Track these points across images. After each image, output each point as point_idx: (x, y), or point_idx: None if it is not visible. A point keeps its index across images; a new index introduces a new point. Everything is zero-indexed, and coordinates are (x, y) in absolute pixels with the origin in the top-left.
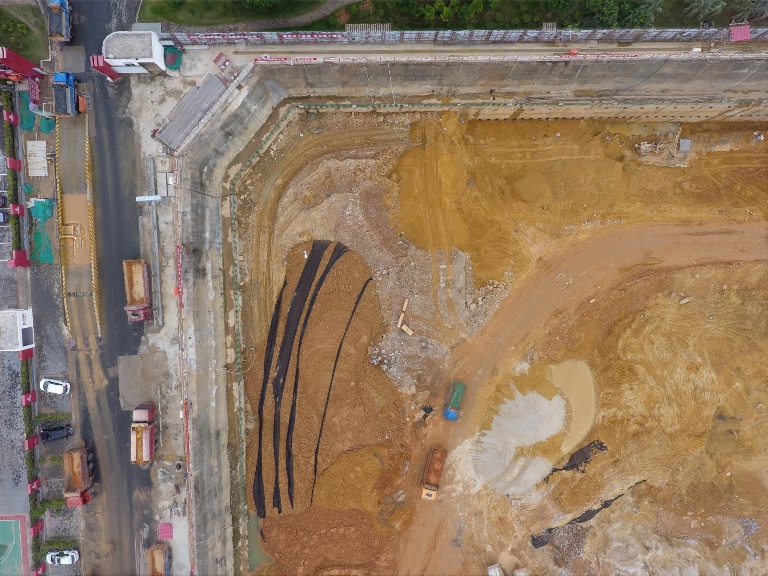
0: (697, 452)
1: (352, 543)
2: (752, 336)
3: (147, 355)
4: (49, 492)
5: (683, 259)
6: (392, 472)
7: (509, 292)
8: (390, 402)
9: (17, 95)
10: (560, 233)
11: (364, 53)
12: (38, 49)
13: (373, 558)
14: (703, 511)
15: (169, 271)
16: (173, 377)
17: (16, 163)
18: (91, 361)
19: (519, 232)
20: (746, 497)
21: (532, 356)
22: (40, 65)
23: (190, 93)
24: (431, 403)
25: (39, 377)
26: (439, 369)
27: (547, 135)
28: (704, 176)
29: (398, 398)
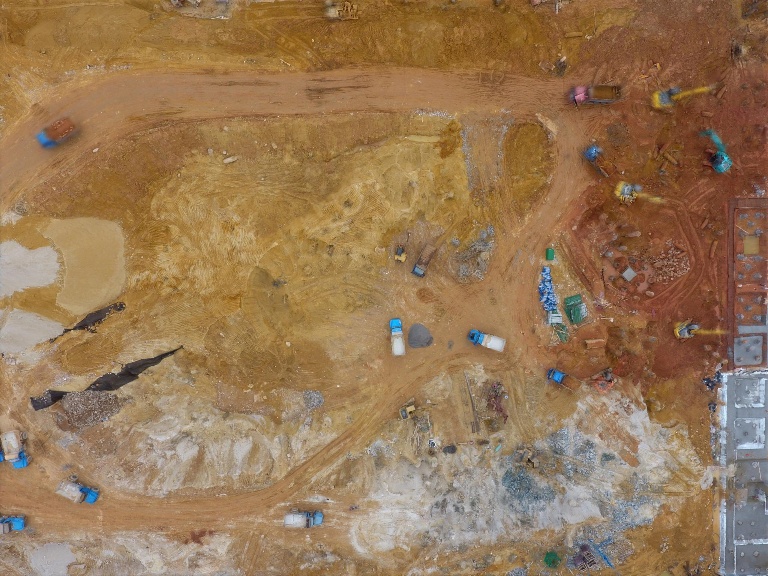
0: (234, 315)
1: None
2: (309, 199)
3: None
4: None
5: (208, 110)
6: None
7: None
8: None
9: None
10: (58, 78)
11: None
12: None
13: None
14: (265, 384)
15: None
16: None
17: None
18: None
19: (12, 76)
20: (308, 368)
21: (21, 206)
22: None
23: None
24: None
25: None
26: None
27: None
28: (248, 28)
29: None
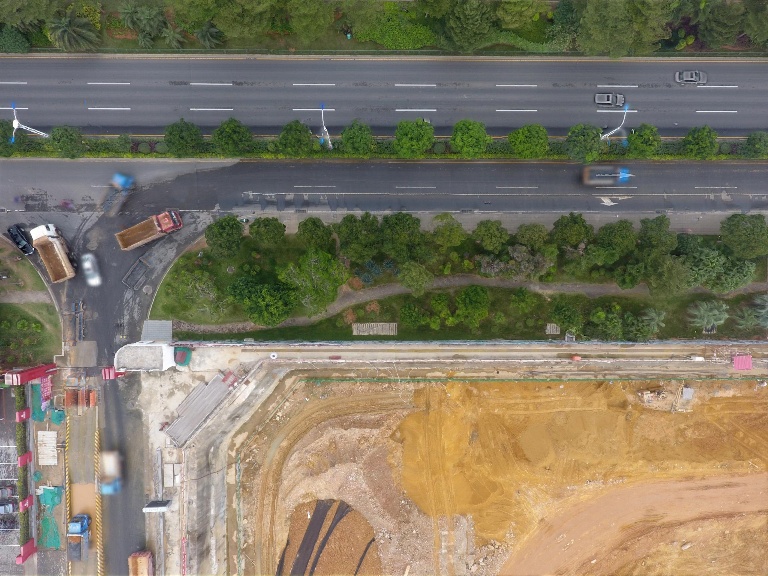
0: None
1: None
2: None
3: None
4: None
5: (685, 513)
6: None
7: (510, 555)
8: None
9: (30, 388)
10: (562, 493)
11: (370, 352)
12: (52, 345)
13: None
14: None
15: (173, 558)
16: None
17: (27, 456)
18: None
19: (521, 493)
20: None
21: None
22: (53, 360)
23: (199, 389)
24: None
25: None
26: None
27: (550, 387)
28: (707, 421)
29: None
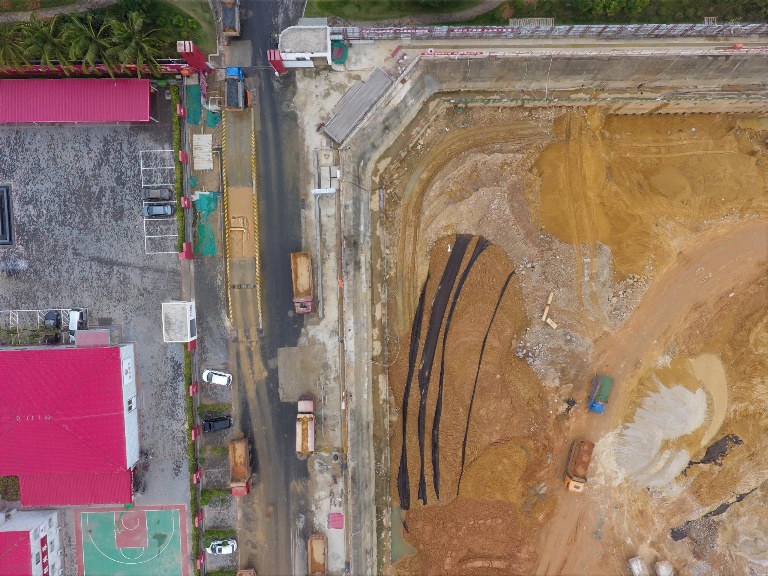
0: None
1: (497, 535)
2: None
3: (306, 347)
4: (208, 482)
5: None
6: (536, 464)
7: (650, 286)
8: (535, 395)
9: (185, 89)
10: (700, 227)
11: (527, 47)
12: (206, 44)
13: (516, 550)
14: None
15: (330, 264)
16: (332, 369)
17: (184, 156)
18: (251, 353)
19: (659, 226)
20: None
21: (674, 350)
22: (208, 60)
23: (355, 87)
24: (574, 396)
25: (200, 368)
26: (583, 362)
27: (682, 130)
28: None
29: (542, 391)
